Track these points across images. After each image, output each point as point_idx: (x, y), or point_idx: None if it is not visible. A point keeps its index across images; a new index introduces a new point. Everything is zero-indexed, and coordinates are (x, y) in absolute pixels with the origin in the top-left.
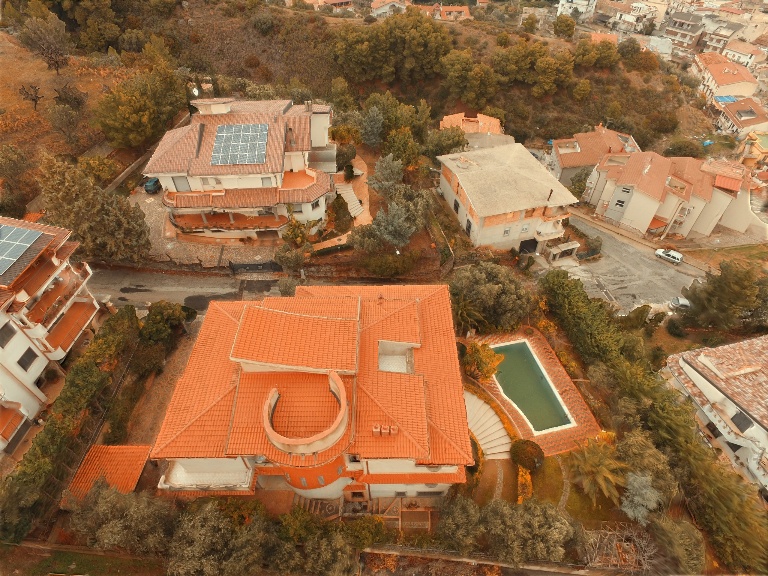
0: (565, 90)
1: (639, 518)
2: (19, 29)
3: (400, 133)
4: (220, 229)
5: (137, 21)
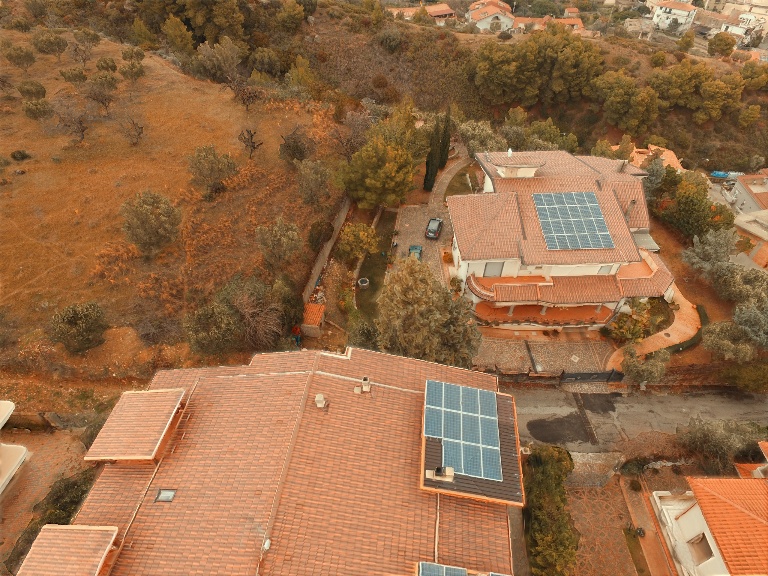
0: (727, 116)
1: None
2: (169, 51)
3: (680, 189)
4: (533, 324)
5: (263, 38)
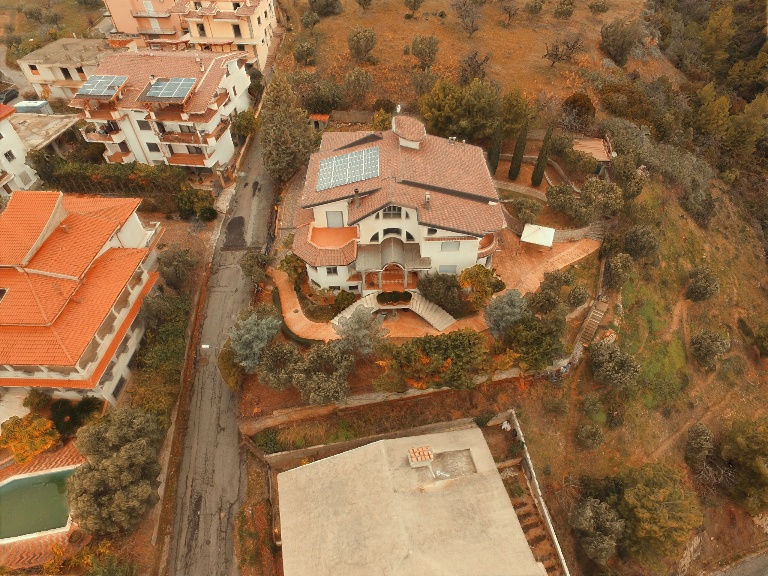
0: None
1: None
2: (656, 27)
3: (506, 355)
4: None
5: None
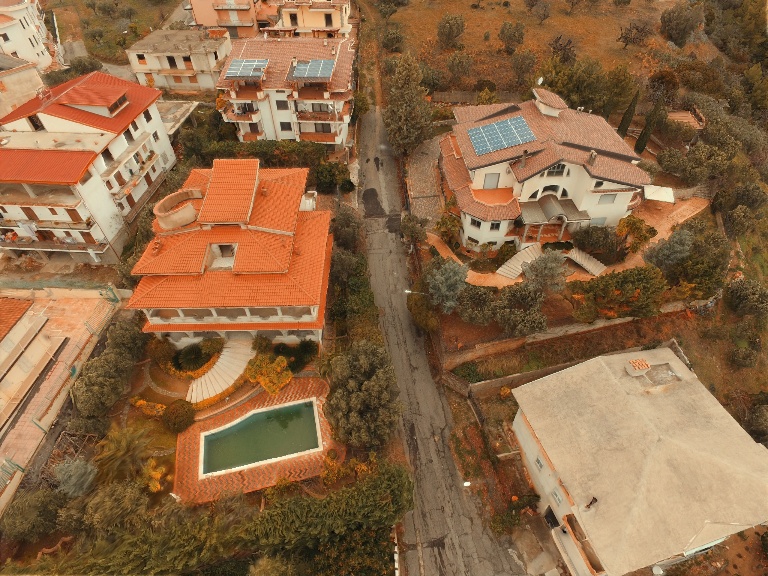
0: None
1: None
2: None
3: (680, 286)
4: None
5: None
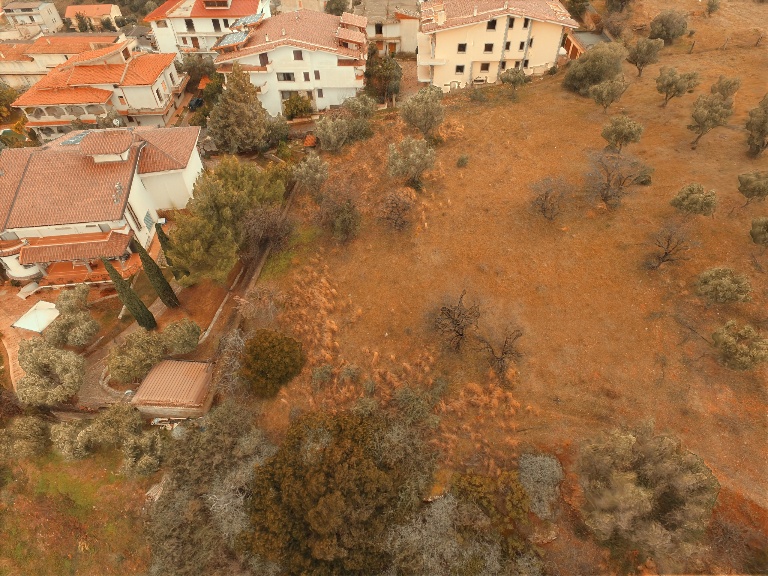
0: None
1: (12, 88)
2: None
3: None
4: None
5: None
